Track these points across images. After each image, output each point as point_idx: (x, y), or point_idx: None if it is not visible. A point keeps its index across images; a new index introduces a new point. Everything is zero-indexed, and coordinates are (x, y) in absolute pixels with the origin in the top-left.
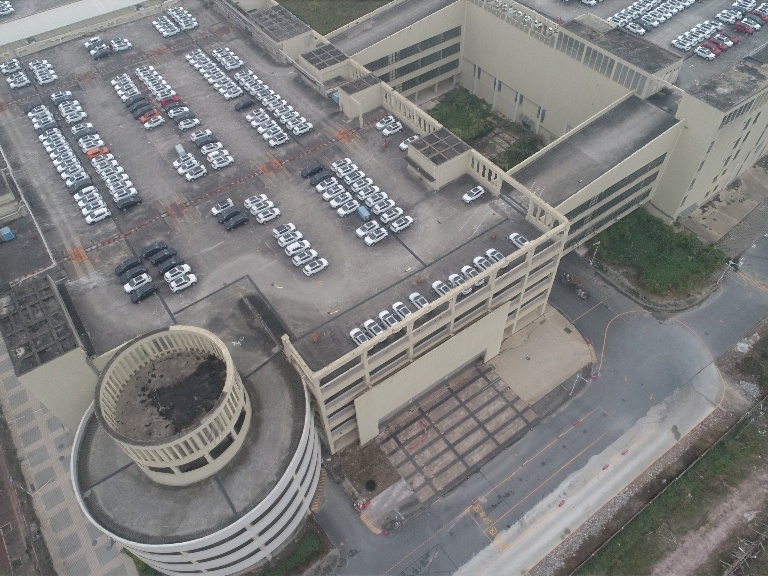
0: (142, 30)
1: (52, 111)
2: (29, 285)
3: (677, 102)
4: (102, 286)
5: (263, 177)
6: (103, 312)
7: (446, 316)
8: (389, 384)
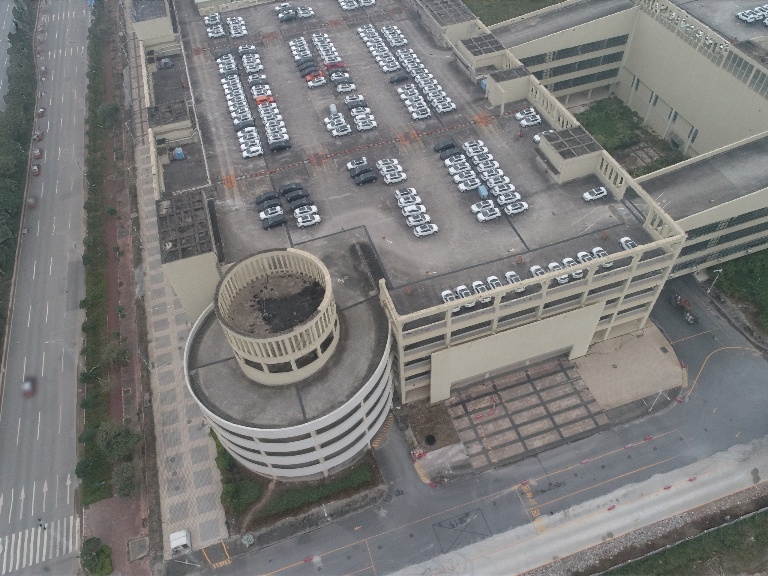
0: (326, 2)
1: (236, 61)
2: (187, 195)
3: None
4: (242, 210)
5: (399, 144)
6: (238, 231)
7: (536, 299)
8: (467, 349)
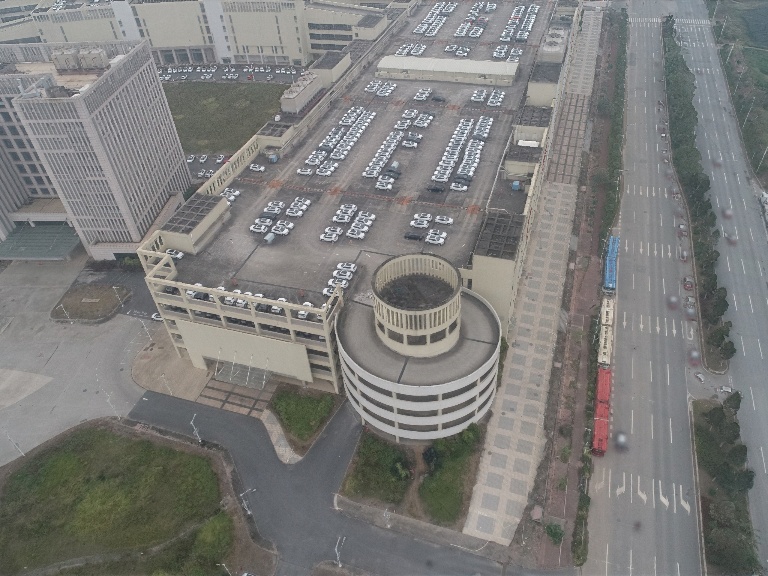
0: (429, 55)
1: None
2: None
3: None
4: None
5: None
6: None
7: None
8: None
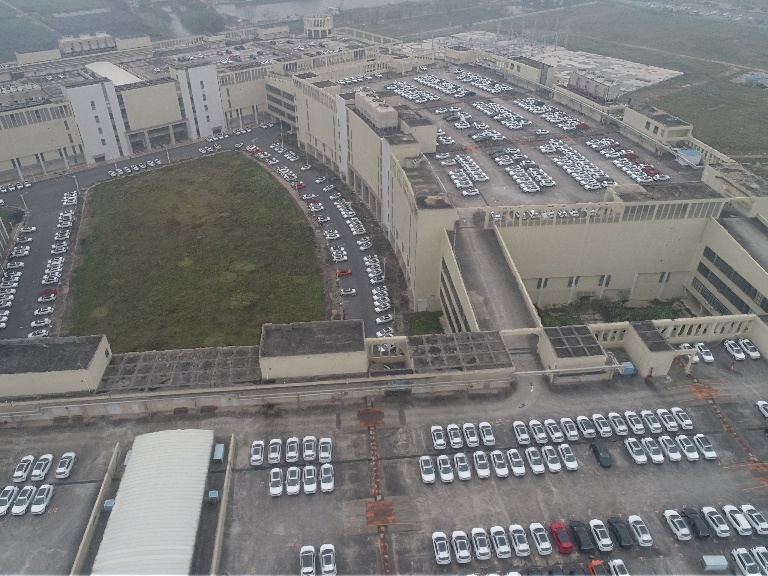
0: (275, 517)
1: None
2: None
3: (748, 207)
4: None
5: None
6: None
7: None
8: None
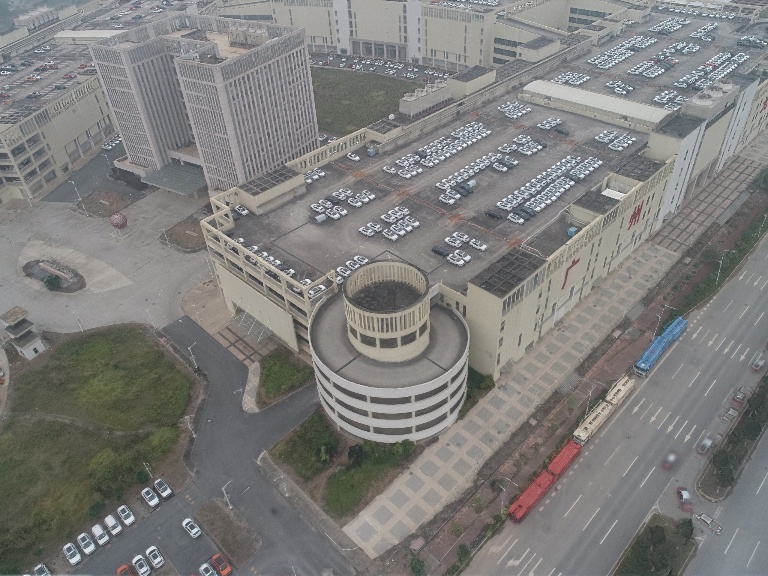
0: (587, 87)
1: None
2: None
3: None
4: None
5: None
6: None
7: None
8: None
